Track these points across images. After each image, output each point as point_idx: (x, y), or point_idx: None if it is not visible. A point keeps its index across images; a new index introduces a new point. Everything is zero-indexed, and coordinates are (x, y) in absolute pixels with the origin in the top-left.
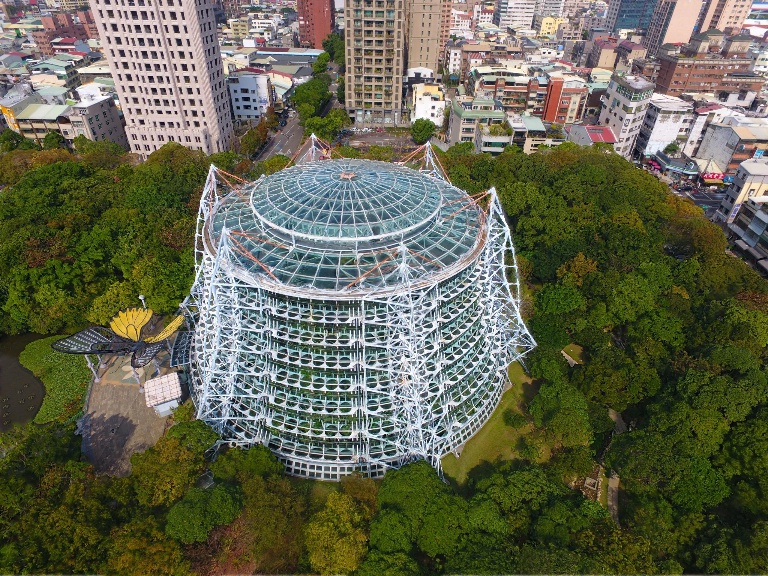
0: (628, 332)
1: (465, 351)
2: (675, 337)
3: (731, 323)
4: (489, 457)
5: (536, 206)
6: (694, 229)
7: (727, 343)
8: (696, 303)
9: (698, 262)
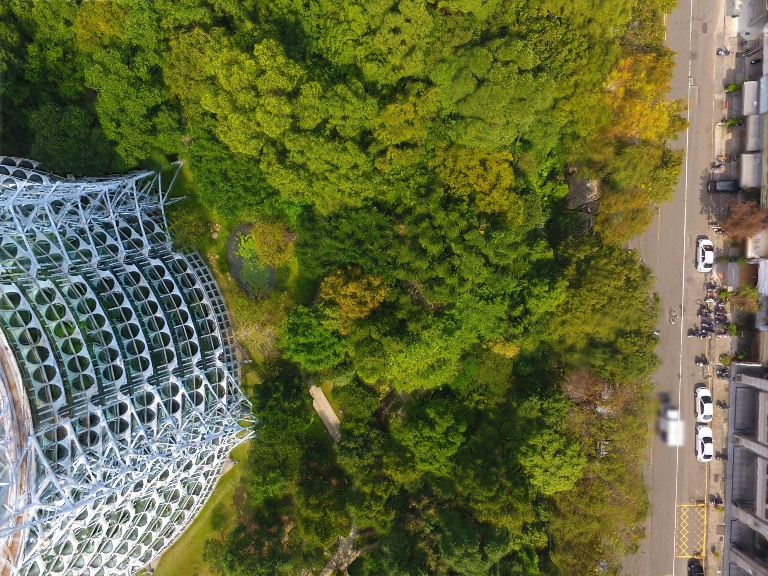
0: (391, 427)
1: (93, 574)
2: (440, 465)
3: (523, 465)
4: (185, 575)
5: (300, 115)
6: (616, 183)
7: (471, 550)
8: (532, 347)
9: (567, 291)
